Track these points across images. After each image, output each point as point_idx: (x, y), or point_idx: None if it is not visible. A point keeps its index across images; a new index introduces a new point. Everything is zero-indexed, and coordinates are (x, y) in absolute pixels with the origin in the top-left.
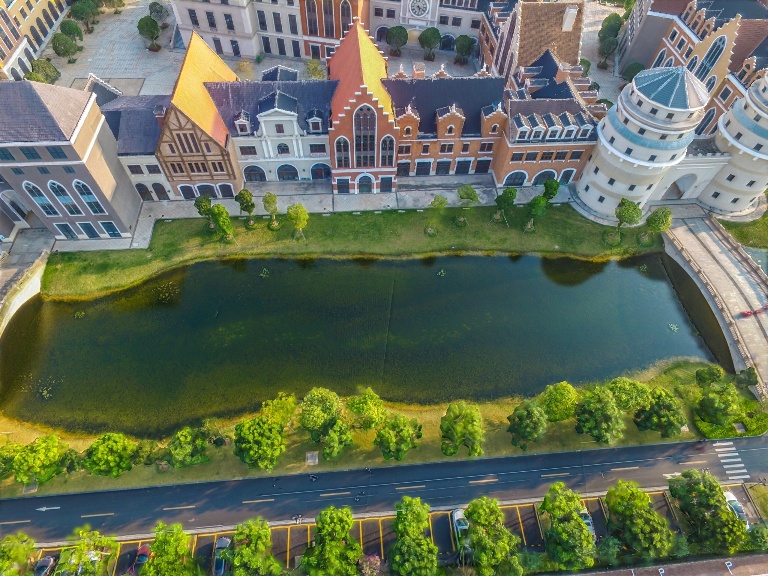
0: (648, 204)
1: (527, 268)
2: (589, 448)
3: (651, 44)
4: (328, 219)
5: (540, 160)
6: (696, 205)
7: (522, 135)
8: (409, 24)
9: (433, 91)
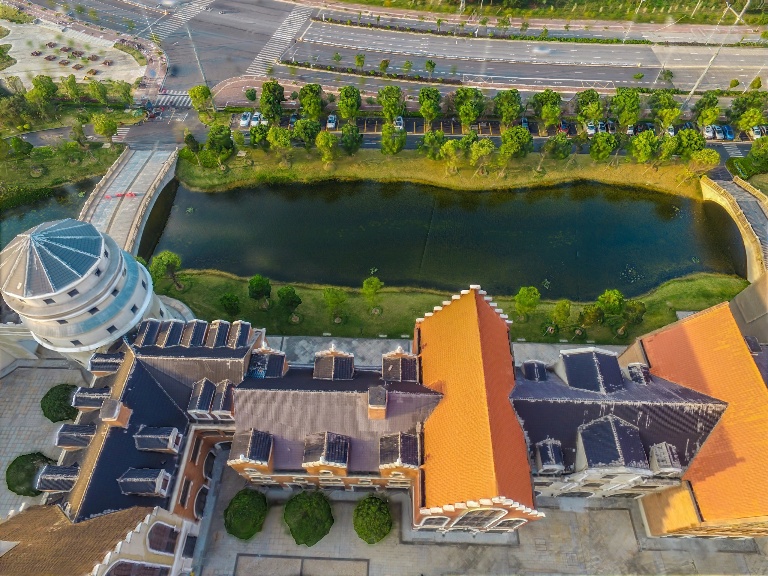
0: None
1: (287, 269)
2: None
3: None
4: None
5: None
6: None
7: None
8: None
9: None
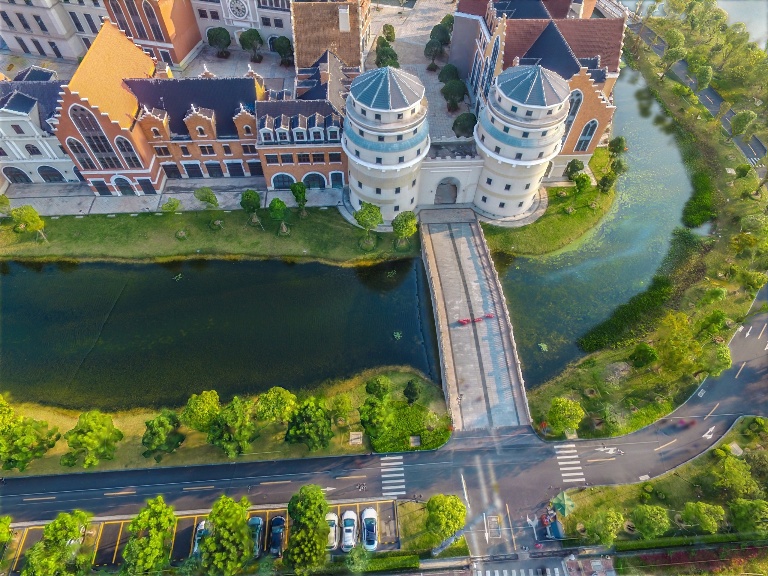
0: (419, 208)
1: (270, 273)
2: (245, 460)
3: (467, 45)
4: (79, 221)
5: (299, 162)
6: (469, 209)
7: (267, 137)
8: (234, 26)
9: (181, 92)
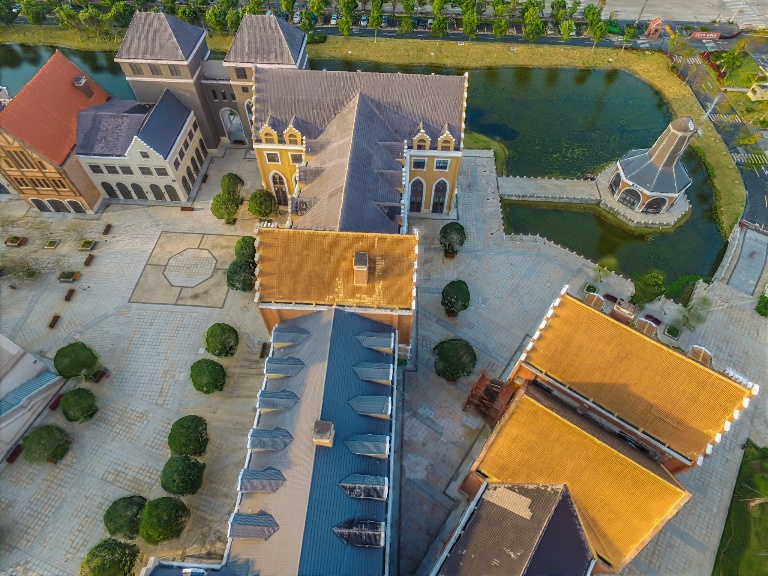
0: None
1: None
2: None
3: None
4: None
5: None
6: None
7: None
8: None
9: None
